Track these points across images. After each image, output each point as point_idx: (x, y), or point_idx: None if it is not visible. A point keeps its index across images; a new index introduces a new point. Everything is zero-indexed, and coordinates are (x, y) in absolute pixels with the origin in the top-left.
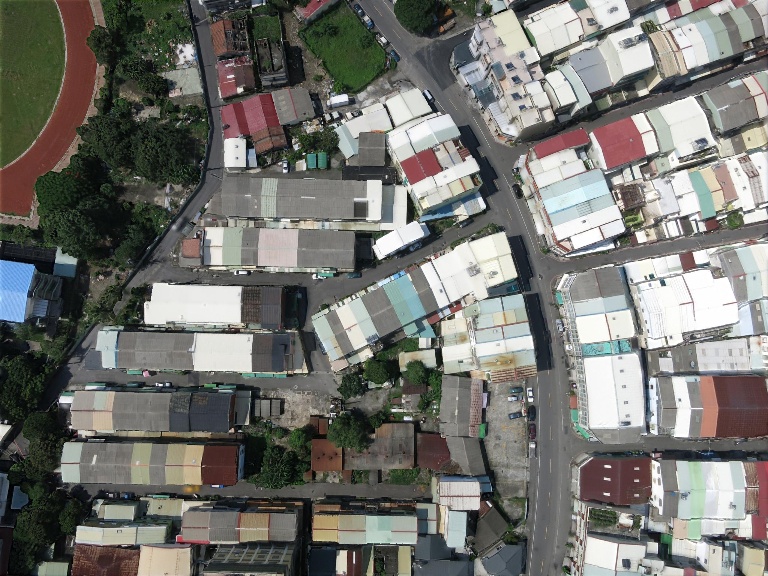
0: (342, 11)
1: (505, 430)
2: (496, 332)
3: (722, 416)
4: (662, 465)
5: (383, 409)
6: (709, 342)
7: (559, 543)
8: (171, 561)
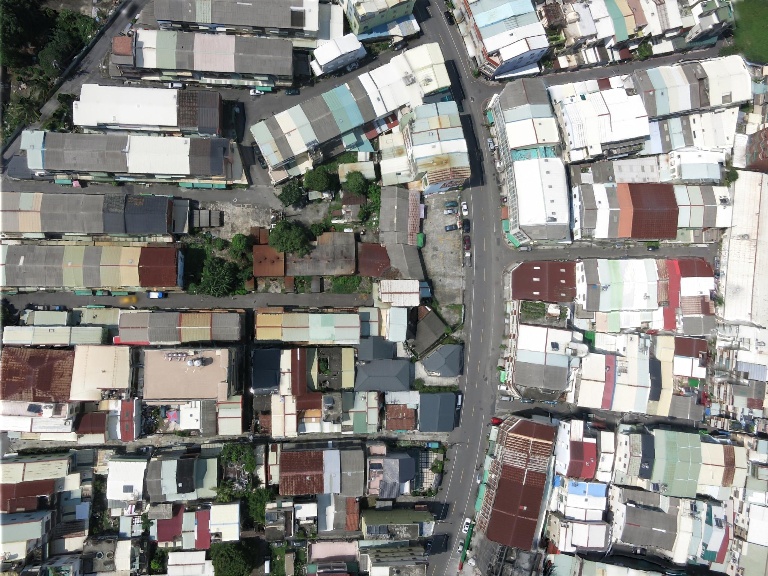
0: None
1: (442, 242)
2: (432, 135)
3: (636, 216)
4: (585, 263)
5: (324, 221)
6: (624, 160)
7: (494, 346)
8: (109, 358)
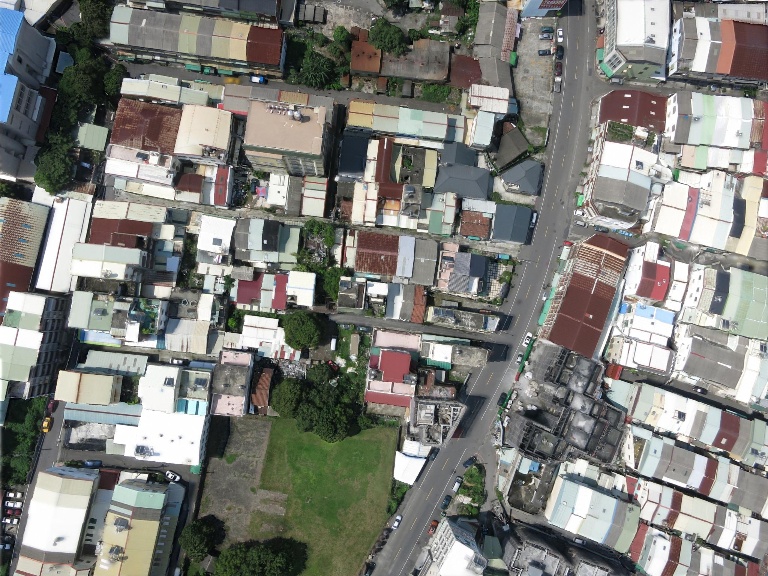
0: None
1: (534, 65)
2: None
3: (738, 52)
4: (679, 94)
5: None
6: (730, 4)
7: (574, 172)
8: (212, 119)
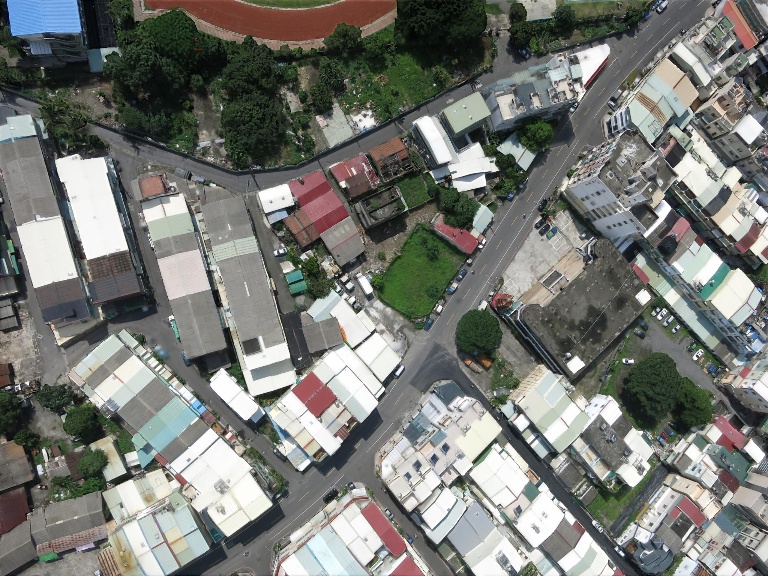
0: (455, 259)
1: None
2: (157, 537)
3: None
4: None
5: (43, 439)
6: None
7: None
8: None
